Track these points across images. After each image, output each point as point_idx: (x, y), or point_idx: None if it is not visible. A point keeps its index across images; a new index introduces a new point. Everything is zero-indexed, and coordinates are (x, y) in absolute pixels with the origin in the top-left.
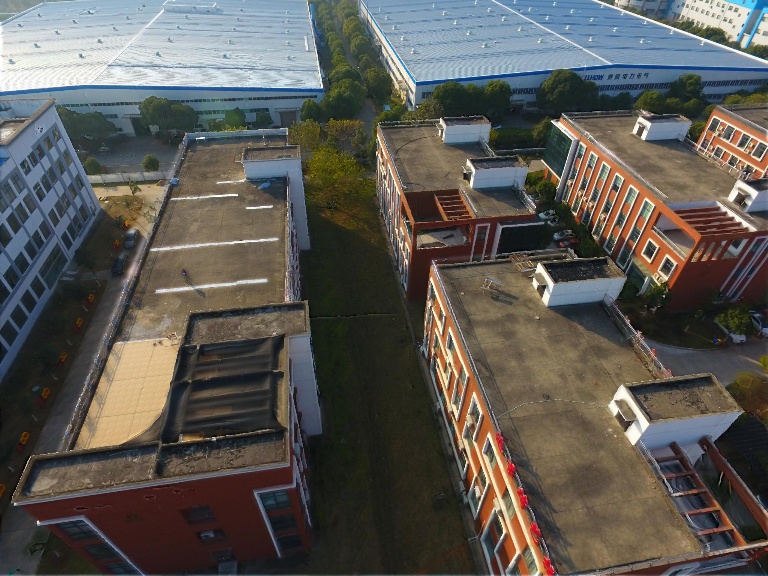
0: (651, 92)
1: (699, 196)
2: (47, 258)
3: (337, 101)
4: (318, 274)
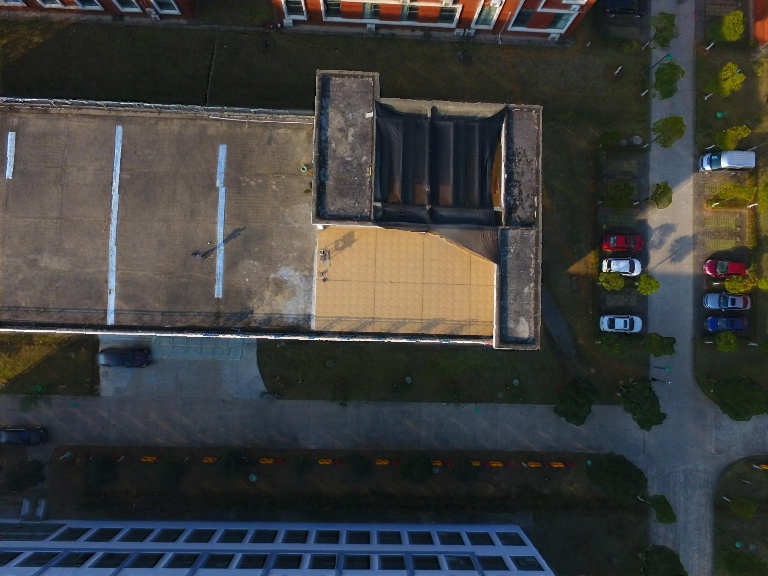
0: None
1: None
2: (4, 541)
3: None
4: None
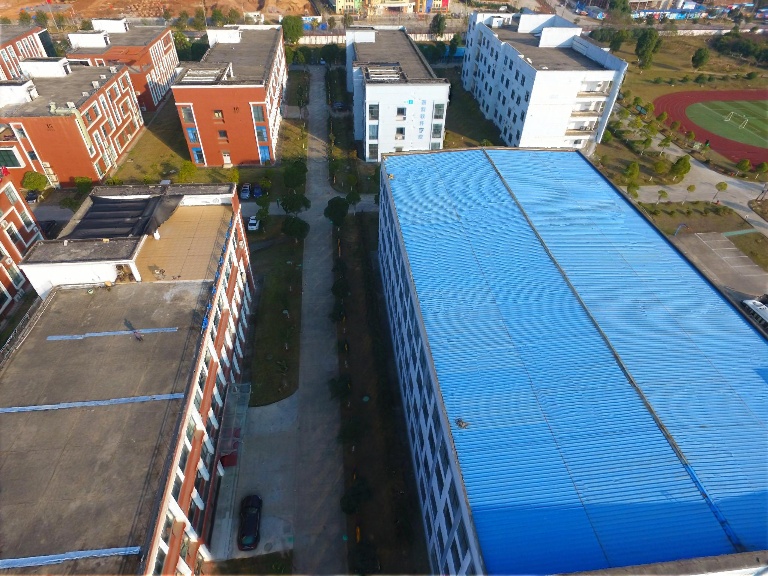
0: None
1: None
2: None
3: None
4: None
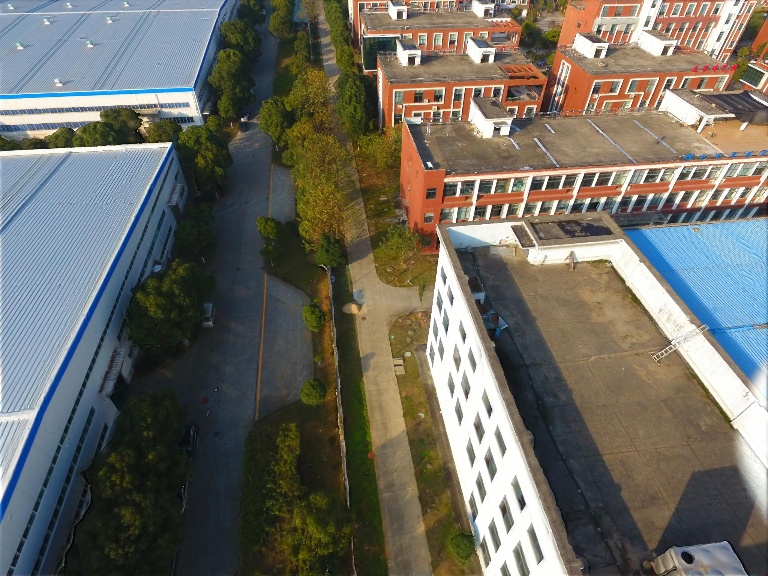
0: (275, 14)
1: (479, 21)
2: None
3: (212, 139)
4: None
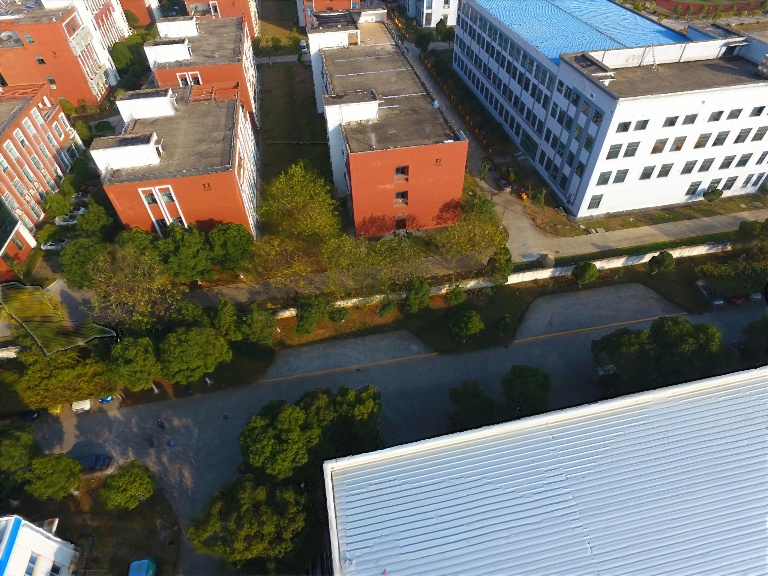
0: None
1: None
2: None
3: None
4: (324, 167)
